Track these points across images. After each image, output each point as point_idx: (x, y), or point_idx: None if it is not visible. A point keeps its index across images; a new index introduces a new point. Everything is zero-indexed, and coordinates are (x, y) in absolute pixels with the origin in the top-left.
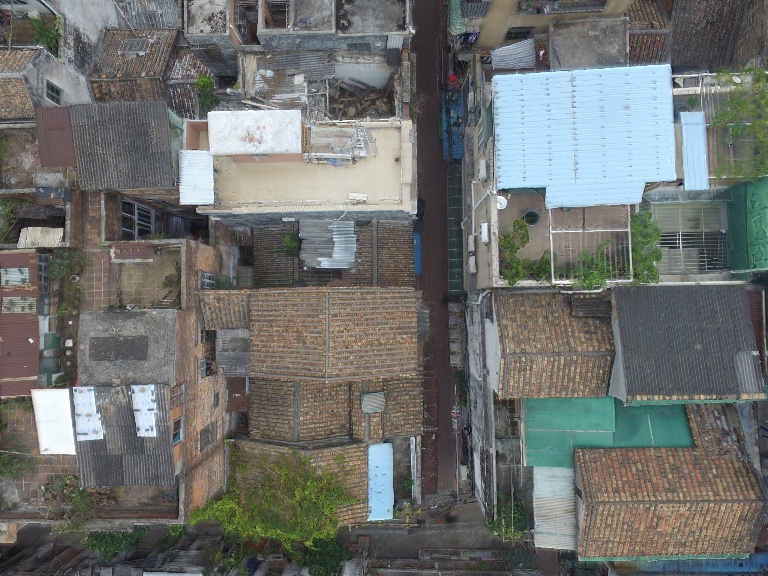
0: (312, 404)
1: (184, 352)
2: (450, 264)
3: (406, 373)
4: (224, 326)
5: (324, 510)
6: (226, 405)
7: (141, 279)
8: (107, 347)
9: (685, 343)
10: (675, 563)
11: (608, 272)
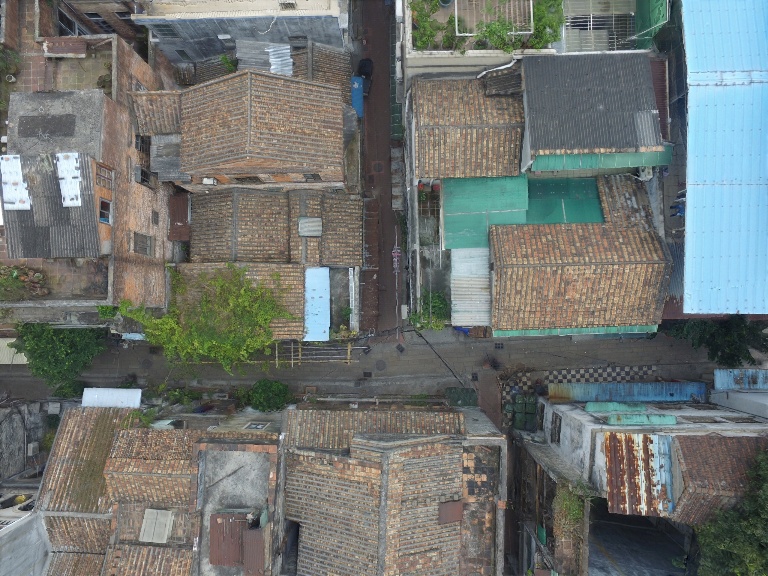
0: (250, 227)
1: (114, 140)
2: (392, 109)
3: (330, 165)
4: (158, 131)
5: (258, 319)
6: (168, 233)
7: (76, 82)
8: (35, 124)
9: (588, 104)
10: (607, 393)
11: (510, 24)
